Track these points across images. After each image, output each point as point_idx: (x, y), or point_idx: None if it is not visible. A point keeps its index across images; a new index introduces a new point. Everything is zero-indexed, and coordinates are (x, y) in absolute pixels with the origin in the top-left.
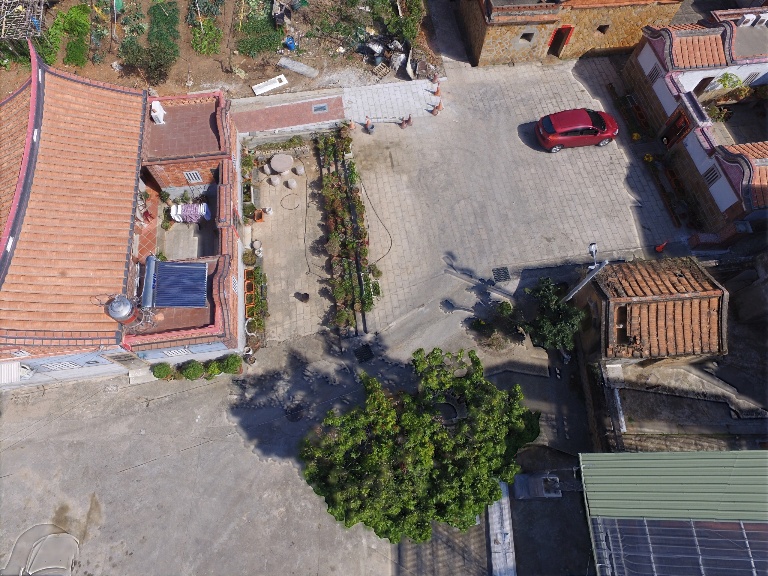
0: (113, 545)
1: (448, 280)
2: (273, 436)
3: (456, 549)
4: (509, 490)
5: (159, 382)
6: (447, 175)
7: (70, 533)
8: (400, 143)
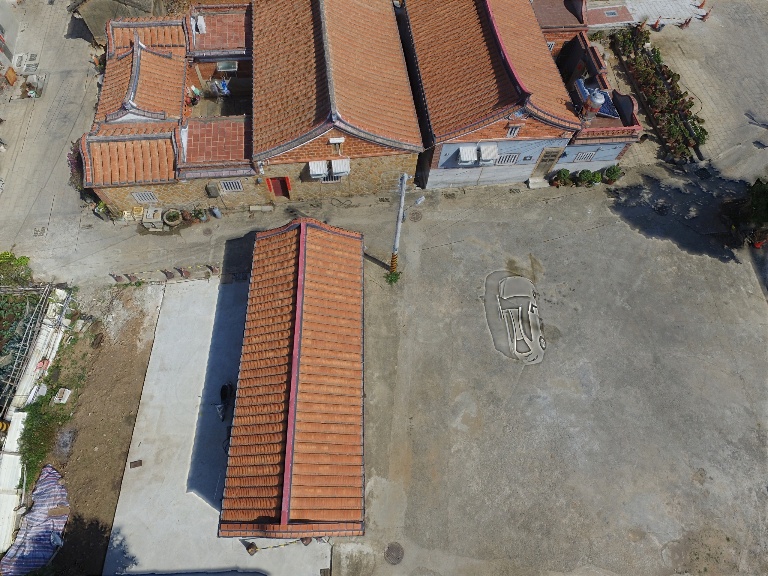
0: (558, 284)
1: (754, 128)
2: (650, 224)
3: None
4: None
5: (550, 188)
6: (728, 61)
7: (523, 276)
8: (684, 39)
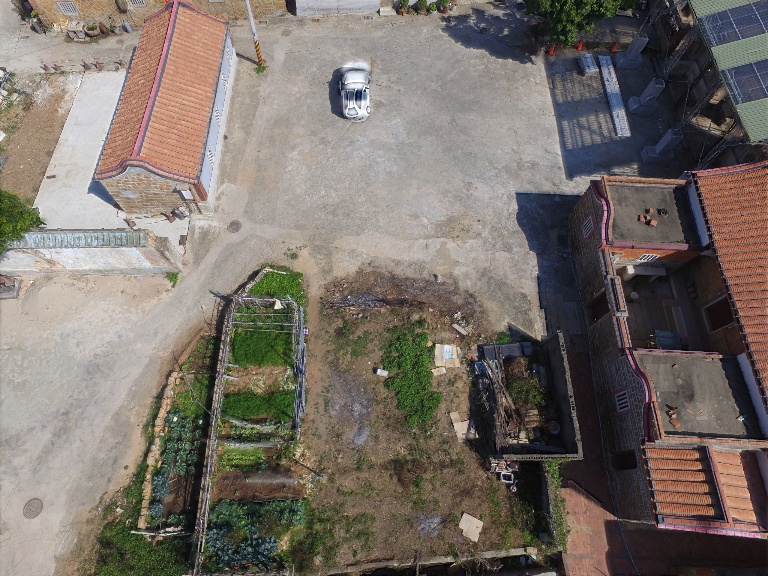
0: (389, 76)
1: None
2: (471, 39)
3: (585, 85)
4: (613, 63)
5: (397, 16)
6: None
7: (363, 70)
8: None
